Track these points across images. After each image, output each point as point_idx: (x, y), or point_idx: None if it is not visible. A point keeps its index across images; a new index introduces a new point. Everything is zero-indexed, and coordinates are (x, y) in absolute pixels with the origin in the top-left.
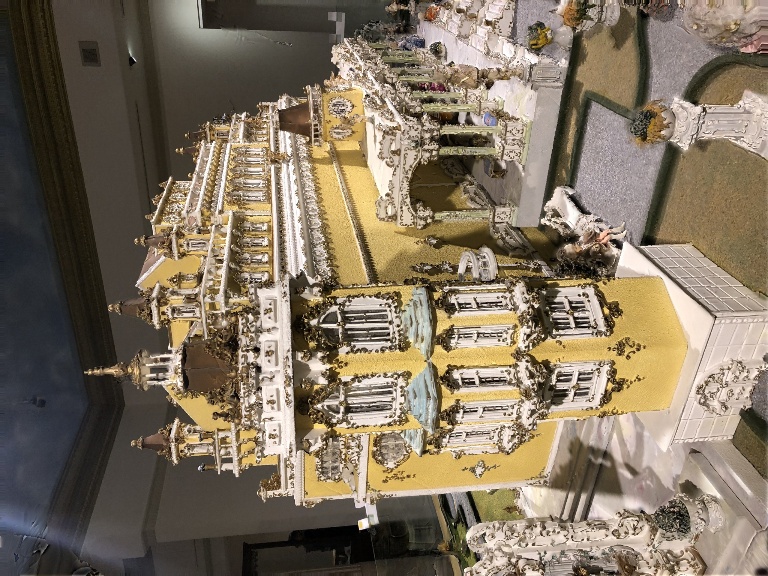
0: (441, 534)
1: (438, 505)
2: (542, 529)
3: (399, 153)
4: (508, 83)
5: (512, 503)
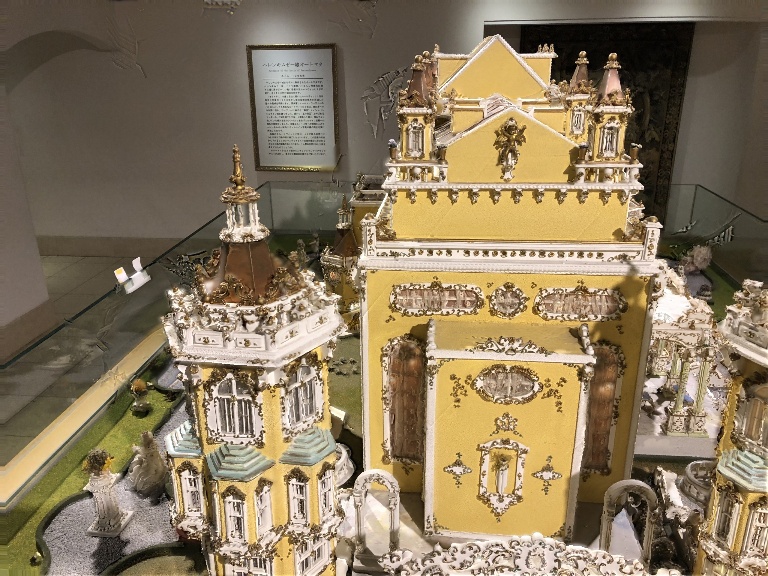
0: (113, 366)
1: (145, 355)
2: None
3: (693, 328)
4: None
5: None
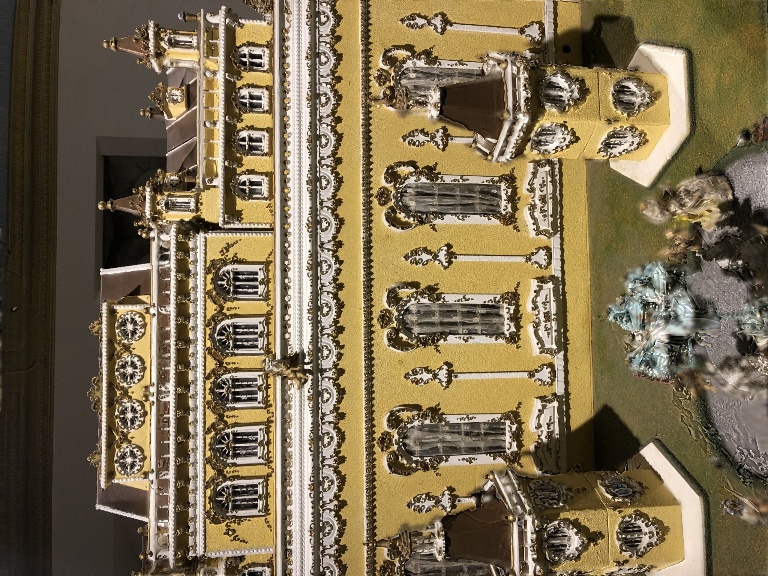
0: None
1: None
2: None
3: None
4: None
5: (640, 3)
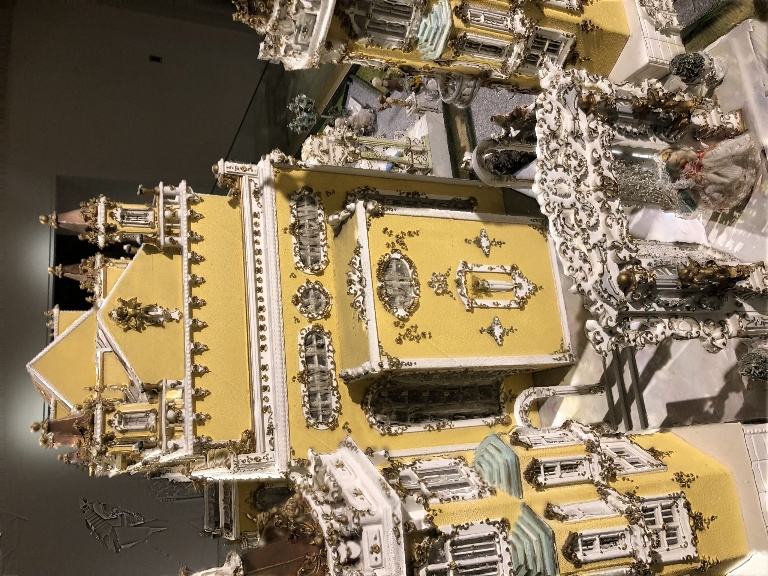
0: None
1: None
2: (586, 71)
3: (328, 150)
4: (397, 150)
5: None
